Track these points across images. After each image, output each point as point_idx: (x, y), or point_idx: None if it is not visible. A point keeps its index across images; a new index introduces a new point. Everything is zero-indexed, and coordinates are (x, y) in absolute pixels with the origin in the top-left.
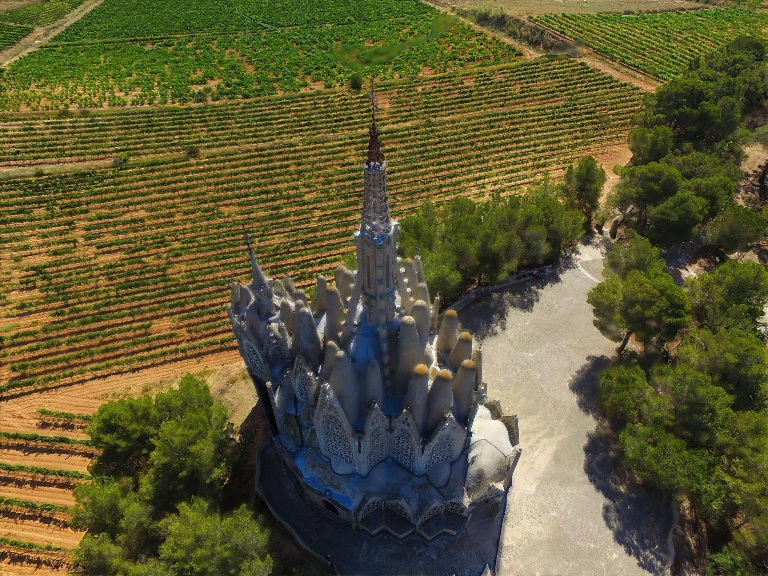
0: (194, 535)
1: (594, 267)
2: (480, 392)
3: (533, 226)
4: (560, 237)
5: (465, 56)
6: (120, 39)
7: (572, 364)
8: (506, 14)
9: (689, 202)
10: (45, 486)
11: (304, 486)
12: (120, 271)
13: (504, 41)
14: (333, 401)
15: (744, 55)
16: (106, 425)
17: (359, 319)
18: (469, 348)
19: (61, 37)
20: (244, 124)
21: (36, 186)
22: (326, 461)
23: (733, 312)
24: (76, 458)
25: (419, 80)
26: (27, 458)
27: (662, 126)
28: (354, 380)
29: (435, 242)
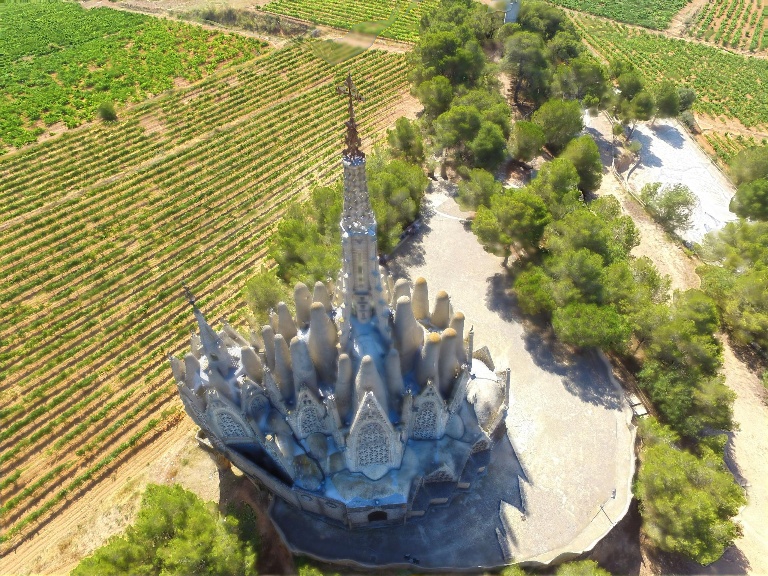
0: None
1: (448, 208)
2: None
3: (396, 190)
4: (415, 192)
5: (213, 58)
6: None
7: (480, 291)
8: (232, 8)
9: (494, 130)
10: None
11: (348, 512)
12: None
13: (243, 35)
14: (378, 406)
15: None
16: None
17: None
18: (448, 303)
19: None
20: None
21: None
22: (359, 476)
23: (567, 200)
24: None
25: (180, 93)
26: None
27: (439, 76)
28: (380, 378)
29: None
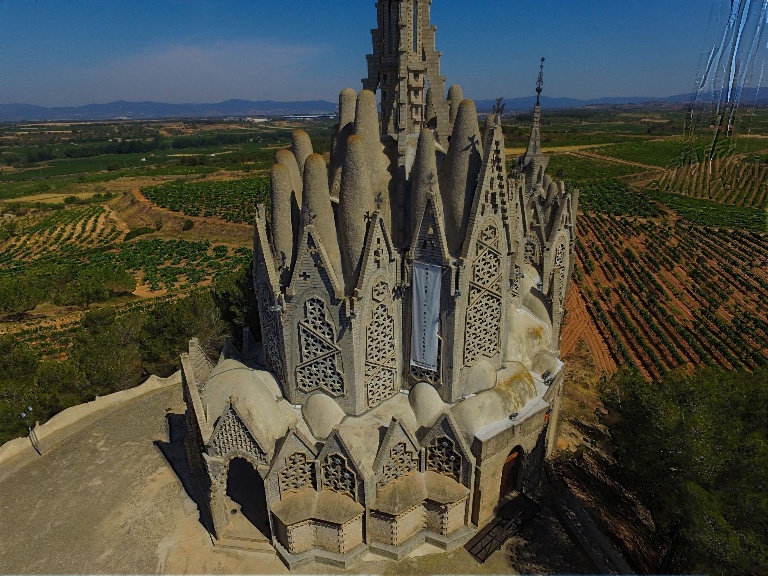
0: None
1: None
2: None
3: None
4: None
5: None
6: None
7: None
8: None
9: None
10: None
11: None
12: None
13: None
14: None
15: None
16: None
17: None
18: None
19: None
20: None
21: None
22: None
23: None
24: None
25: None
26: None
27: None
28: None
29: None
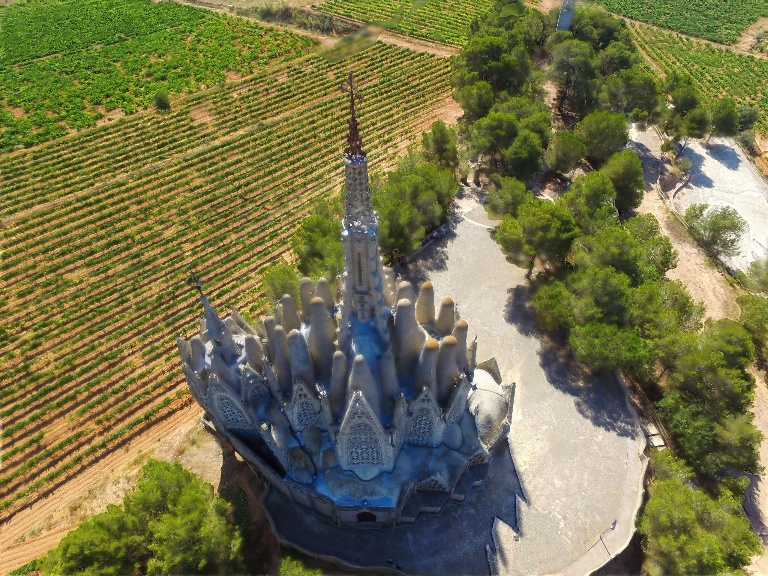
0: None
1: (476, 215)
2: (475, 346)
3: (423, 193)
4: (444, 197)
5: (266, 54)
6: None
7: (499, 301)
8: (289, 6)
9: (531, 138)
10: None
11: (336, 510)
12: None
13: (297, 33)
14: (366, 406)
15: None
16: (77, 560)
17: (348, 321)
18: (453, 311)
19: None
20: (45, 176)
21: None
22: (350, 475)
23: (599, 215)
24: None
25: (230, 86)
26: None
27: (481, 81)
28: (373, 379)
29: None
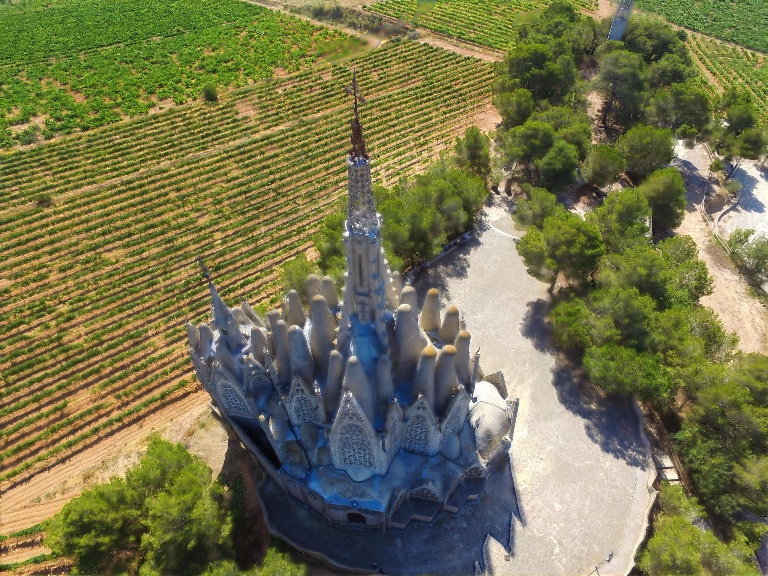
0: None
1: (504, 224)
2: (478, 357)
3: (449, 199)
4: (471, 204)
5: None
6: None
7: (517, 314)
8: (340, 6)
9: (566, 150)
10: None
11: (326, 507)
12: None
13: (346, 32)
14: (357, 408)
15: (561, 18)
16: (77, 527)
17: (349, 322)
18: (458, 320)
19: None
20: (96, 159)
21: None
22: (343, 474)
23: (630, 233)
24: None
25: (276, 82)
26: None
27: (521, 89)
28: (367, 382)
29: None
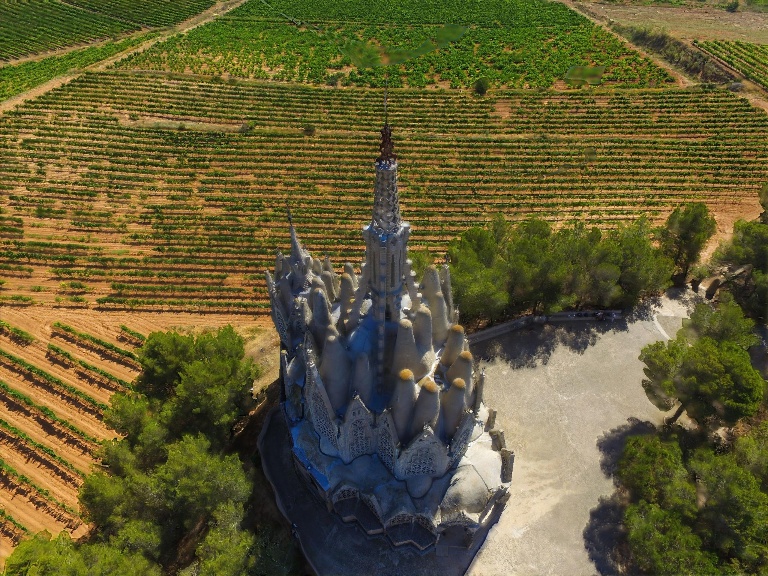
0: (186, 465)
1: (673, 325)
2: (468, 415)
3: (606, 264)
4: (638, 283)
5: (607, 75)
6: (281, 19)
7: (609, 420)
8: (668, 35)
9: None
10: (107, 389)
11: (293, 454)
12: (218, 224)
13: (657, 64)
14: (316, 381)
15: None
16: (151, 350)
17: (367, 312)
18: (467, 368)
19: (234, 12)
20: (363, 112)
21: (176, 138)
22: (316, 438)
23: None
24: (136, 373)
25: (548, 93)
26: (102, 362)
27: None
28: (343, 367)
29: (496, 258)
